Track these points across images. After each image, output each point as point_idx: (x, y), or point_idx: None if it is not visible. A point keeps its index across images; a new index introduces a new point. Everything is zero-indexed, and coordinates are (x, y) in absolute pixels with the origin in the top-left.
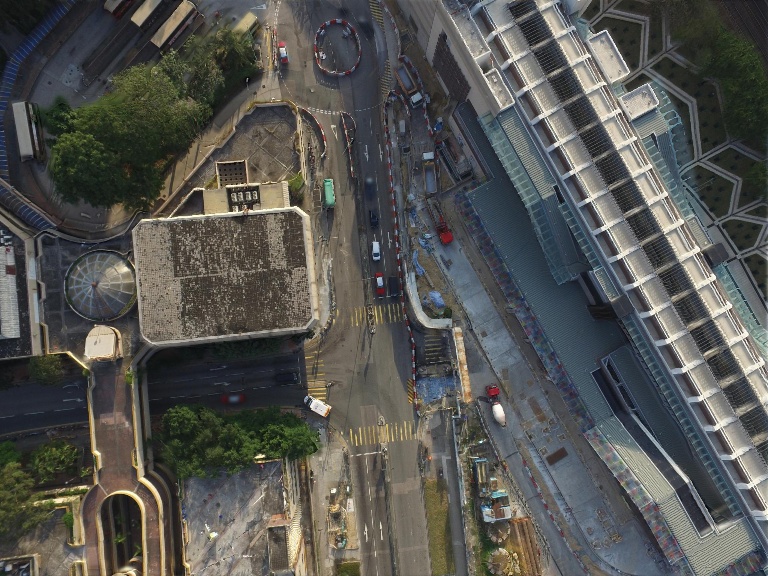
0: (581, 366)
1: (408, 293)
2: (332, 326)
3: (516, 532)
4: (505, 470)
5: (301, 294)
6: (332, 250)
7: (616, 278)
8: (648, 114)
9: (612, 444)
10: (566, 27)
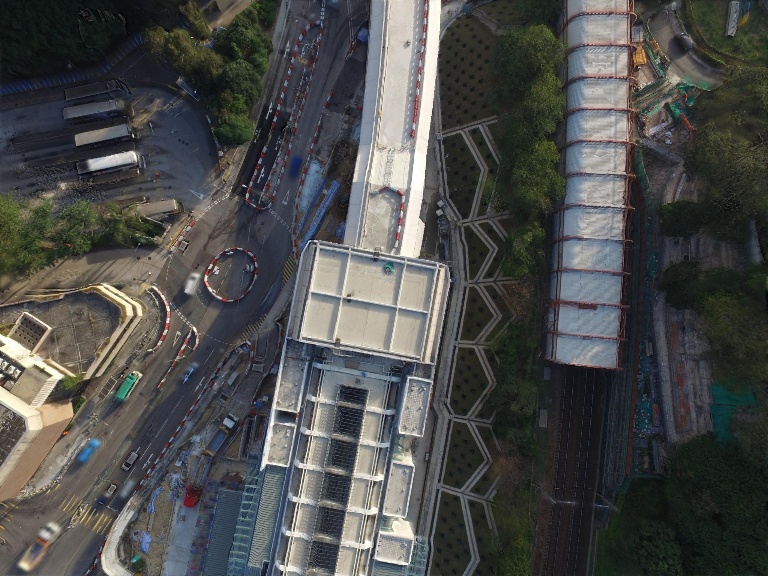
0: None
1: None
2: (44, 494)
3: None
4: None
5: None
6: (96, 432)
7: None
8: (394, 564)
9: None
10: (378, 440)
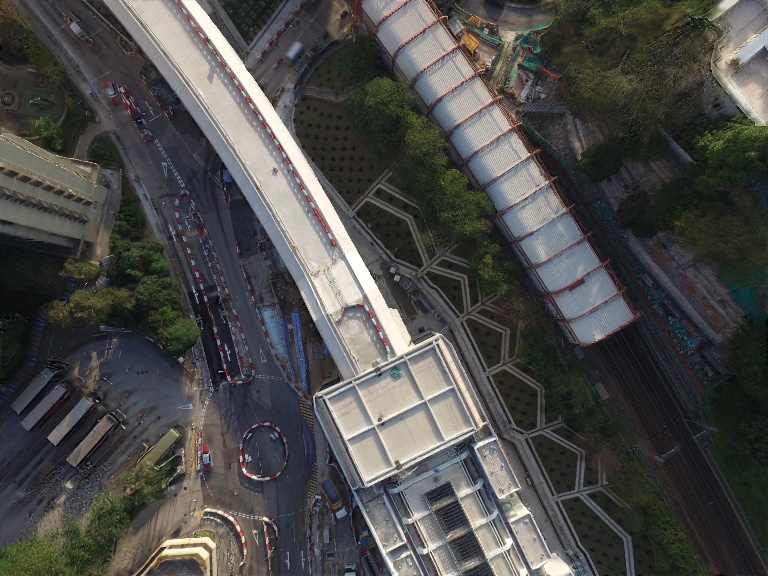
0: None
1: None
2: None
3: None
4: None
5: None
6: None
7: None
8: None
9: None
10: (486, 515)
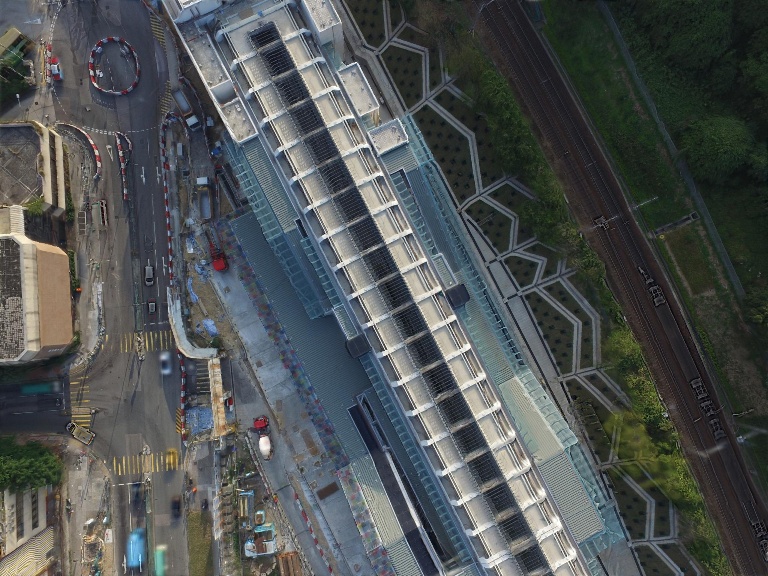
0: (338, 402)
1: (169, 321)
2: (100, 351)
3: (280, 567)
4: (276, 503)
5: (15, 324)
6: (103, 274)
7: (355, 316)
8: (398, 149)
9: (360, 483)
10: (311, 58)
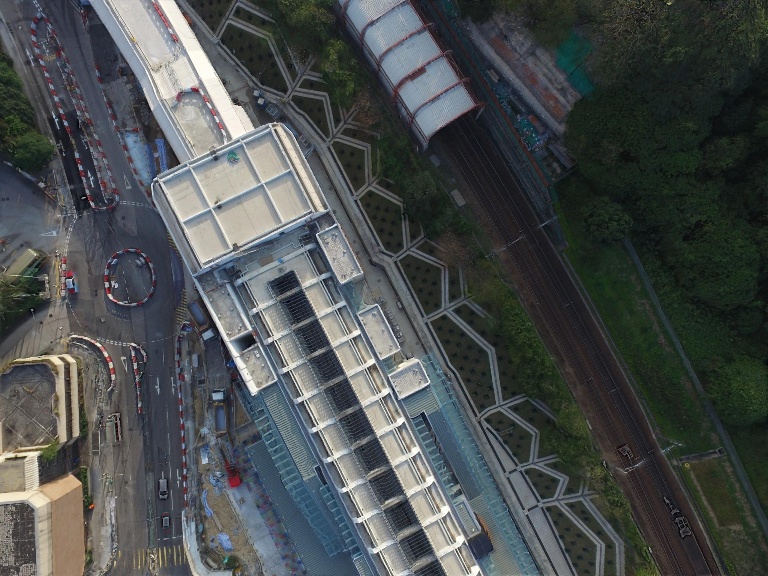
0: None
1: (184, 547)
2: (113, 568)
3: None
4: None
5: None
6: (117, 488)
7: (376, 567)
8: (419, 392)
9: None
10: (332, 304)
